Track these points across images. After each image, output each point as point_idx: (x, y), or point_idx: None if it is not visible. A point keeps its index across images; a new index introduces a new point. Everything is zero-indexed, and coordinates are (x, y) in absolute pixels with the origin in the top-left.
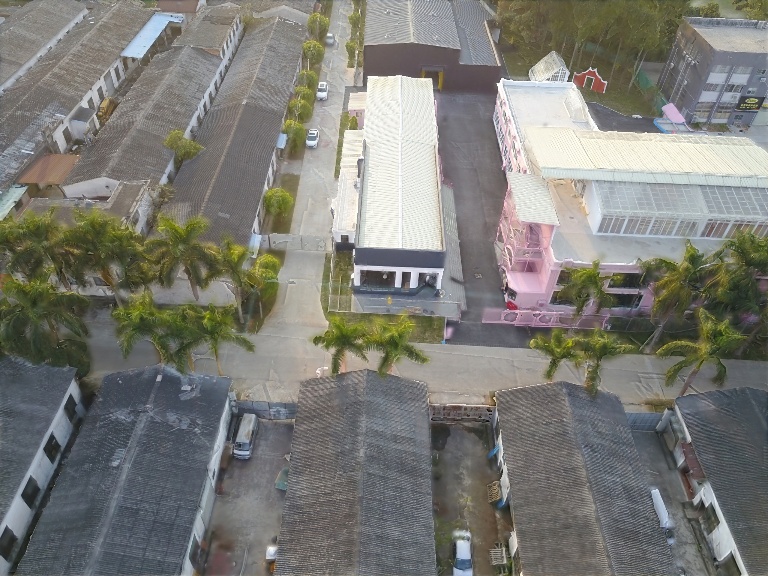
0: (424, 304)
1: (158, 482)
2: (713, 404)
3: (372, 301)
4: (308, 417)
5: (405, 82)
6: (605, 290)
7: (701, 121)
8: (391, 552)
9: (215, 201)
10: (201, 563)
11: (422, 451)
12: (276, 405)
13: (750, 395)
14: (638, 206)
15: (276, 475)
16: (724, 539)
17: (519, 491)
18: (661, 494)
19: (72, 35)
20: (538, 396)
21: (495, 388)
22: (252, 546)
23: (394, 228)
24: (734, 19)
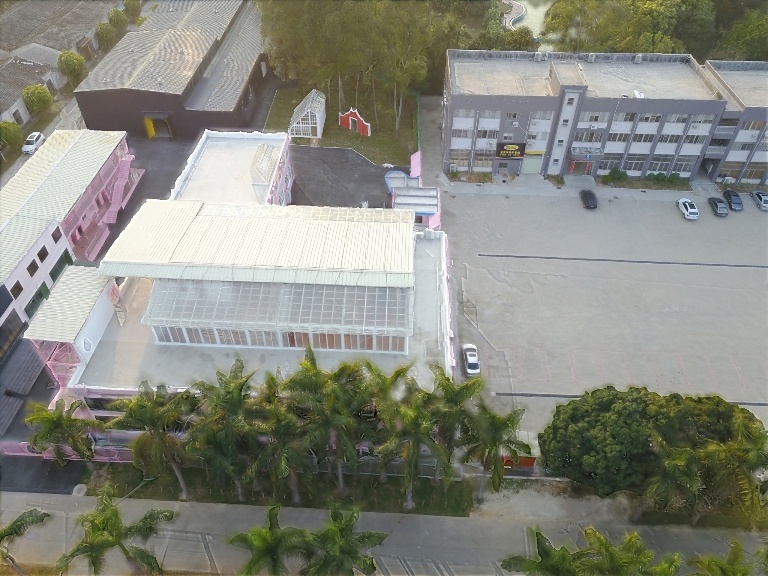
0: None
1: None
2: None
3: None
4: None
5: (85, 138)
6: None
7: (462, 170)
8: None
9: None
10: None
11: None
12: None
13: None
14: (193, 313)
15: None
16: None
17: None
18: None
19: None
20: None
21: None
22: None
23: None
24: (507, 51)
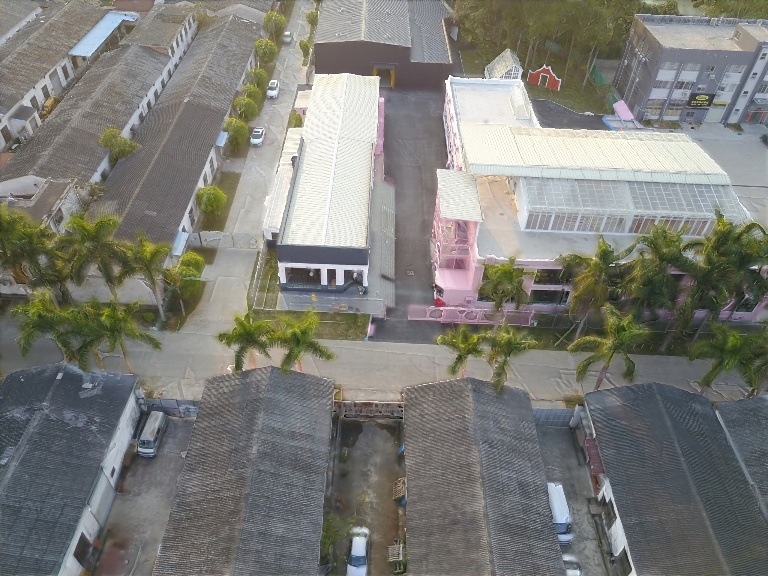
0: (350, 301)
1: (46, 480)
2: (620, 399)
3: (298, 298)
4: (209, 414)
5: (351, 80)
6: (531, 286)
7: (653, 118)
8: (272, 549)
9: (143, 199)
10: (93, 561)
11: (320, 448)
12: (184, 403)
13: (656, 390)
14: (564, 202)
15: (180, 473)
16: (619, 534)
17: (414, 487)
18: (568, 490)
19: (21, 34)
20: (444, 392)
21: (413, 385)
22: (147, 544)
23: (319, 225)
24: None
